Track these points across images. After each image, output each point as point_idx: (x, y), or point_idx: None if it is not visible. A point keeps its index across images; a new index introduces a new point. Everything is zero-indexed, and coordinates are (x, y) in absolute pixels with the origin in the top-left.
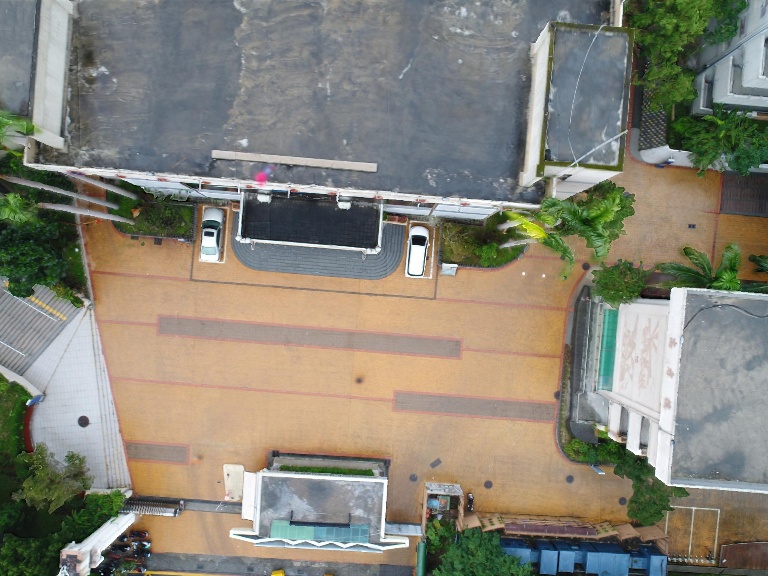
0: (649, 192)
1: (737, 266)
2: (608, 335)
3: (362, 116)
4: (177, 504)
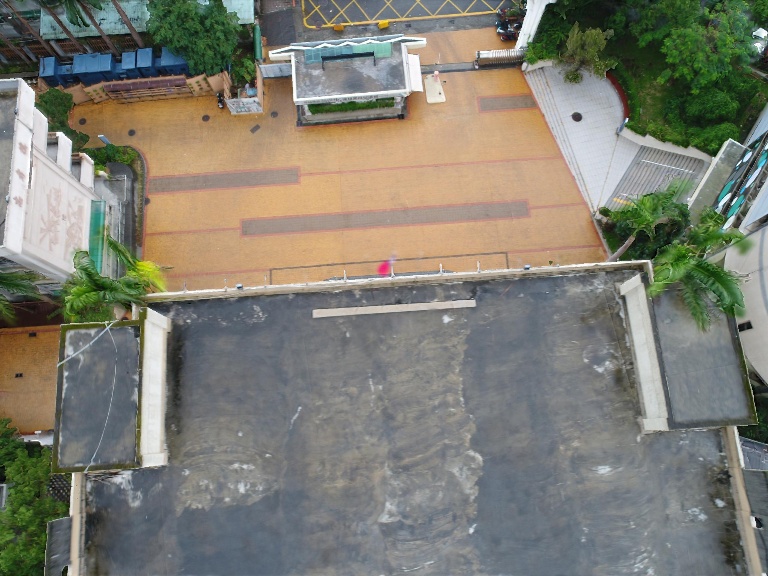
0: None
1: None
2: (97, 250)
3: (334, 363)
4: (481, 65)
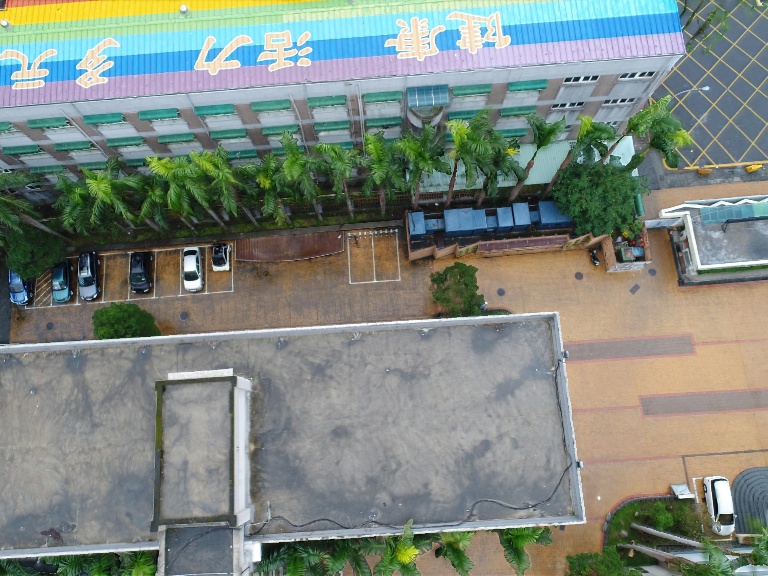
0: None
1: None
2: None
3: None
4: None
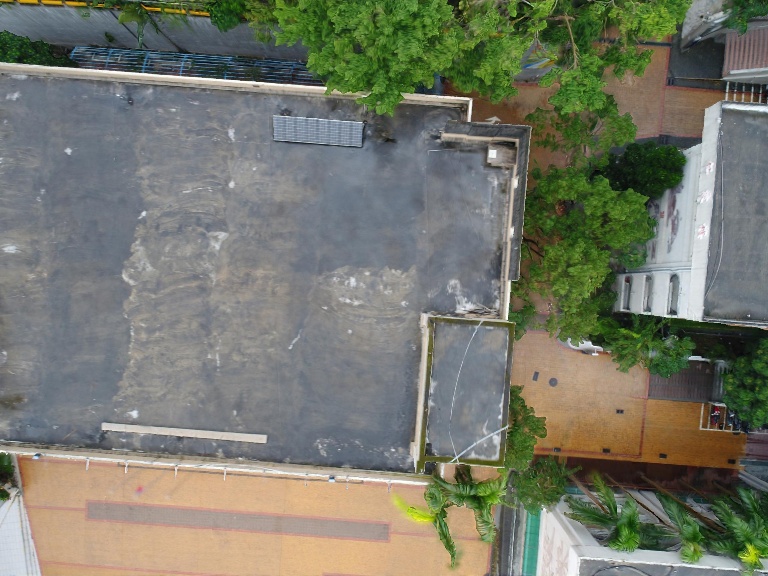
0: (576, 378)
1: (666, 451)
2: (531, 532)
3: (252, 387)
4: None
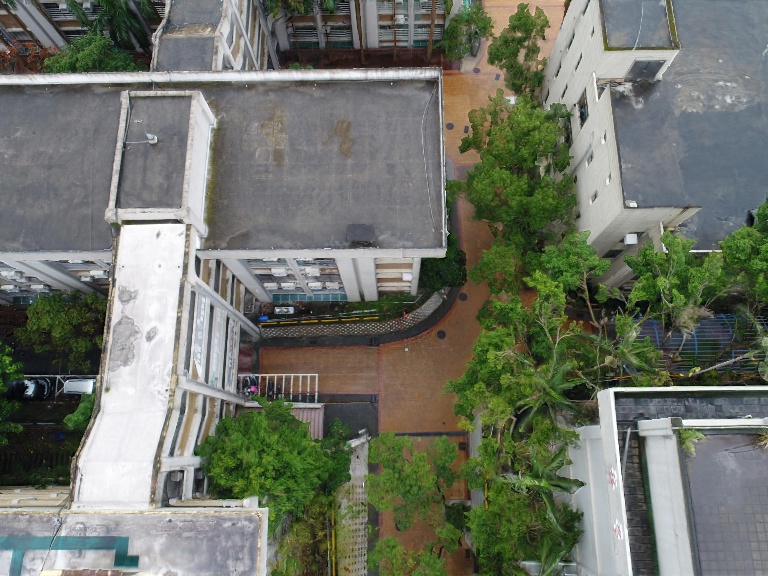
0: None
1: None
2: (465, 1)
3: None
4: None
